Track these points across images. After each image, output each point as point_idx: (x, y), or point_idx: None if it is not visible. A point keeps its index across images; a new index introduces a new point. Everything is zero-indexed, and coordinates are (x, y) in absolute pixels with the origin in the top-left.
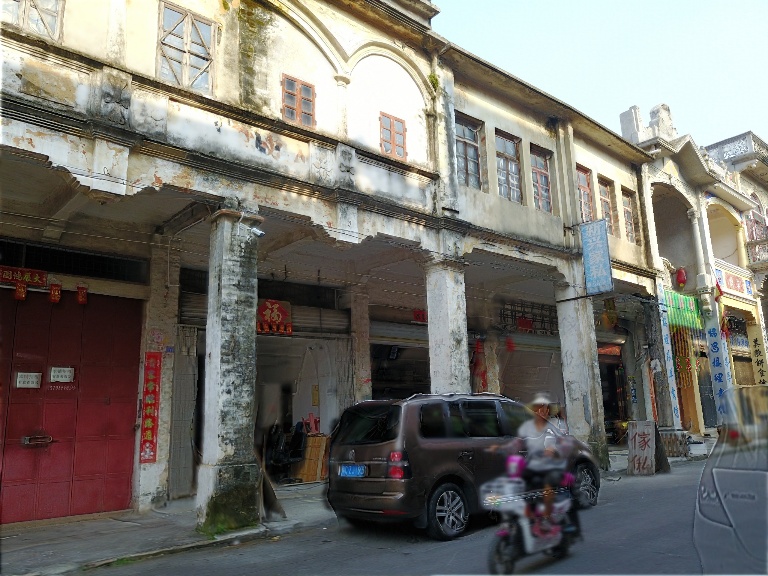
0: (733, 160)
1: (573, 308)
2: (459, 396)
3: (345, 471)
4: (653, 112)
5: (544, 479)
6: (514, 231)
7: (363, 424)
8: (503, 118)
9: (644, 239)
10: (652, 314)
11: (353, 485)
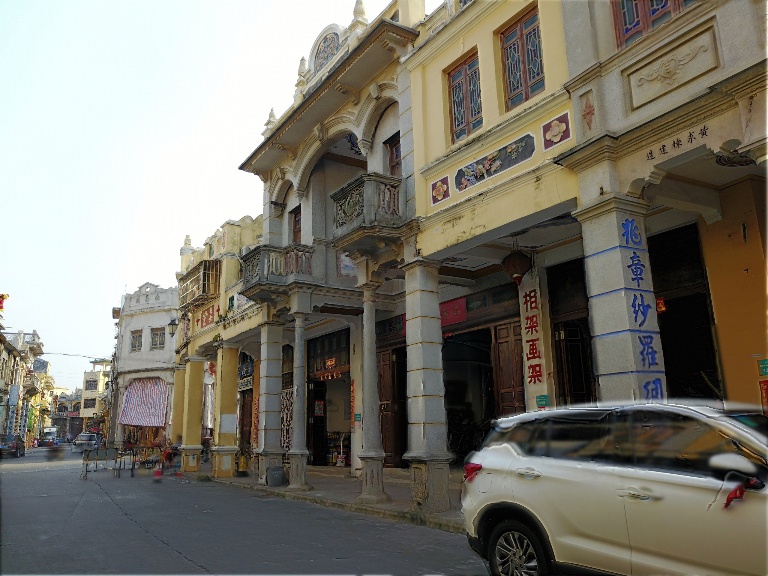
0: (29, 343)
1: (2, 408)
2: (17, 434)
3: (0, 447)
4: (20, 333)
5: (22, 450)
6: (0, 388)
7: (1, 439)
8: (4, 354)
9: (11, 382)
10: (7, 407)
11: (3, 450)
